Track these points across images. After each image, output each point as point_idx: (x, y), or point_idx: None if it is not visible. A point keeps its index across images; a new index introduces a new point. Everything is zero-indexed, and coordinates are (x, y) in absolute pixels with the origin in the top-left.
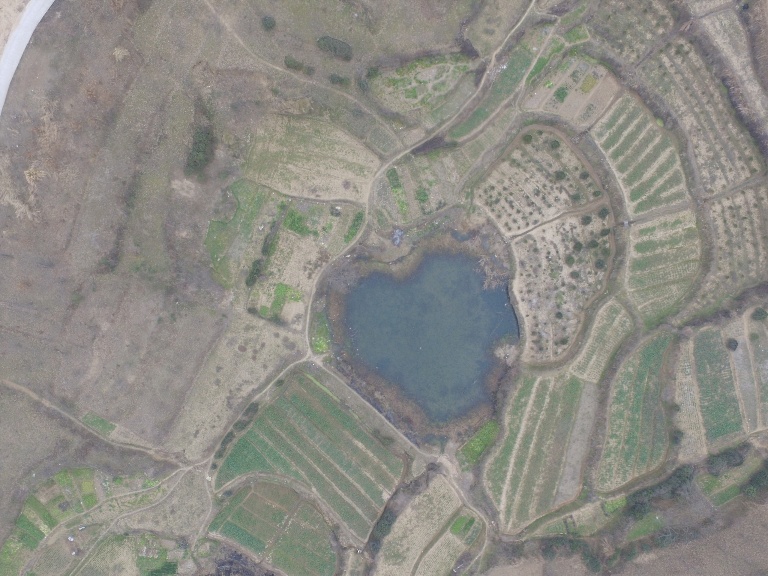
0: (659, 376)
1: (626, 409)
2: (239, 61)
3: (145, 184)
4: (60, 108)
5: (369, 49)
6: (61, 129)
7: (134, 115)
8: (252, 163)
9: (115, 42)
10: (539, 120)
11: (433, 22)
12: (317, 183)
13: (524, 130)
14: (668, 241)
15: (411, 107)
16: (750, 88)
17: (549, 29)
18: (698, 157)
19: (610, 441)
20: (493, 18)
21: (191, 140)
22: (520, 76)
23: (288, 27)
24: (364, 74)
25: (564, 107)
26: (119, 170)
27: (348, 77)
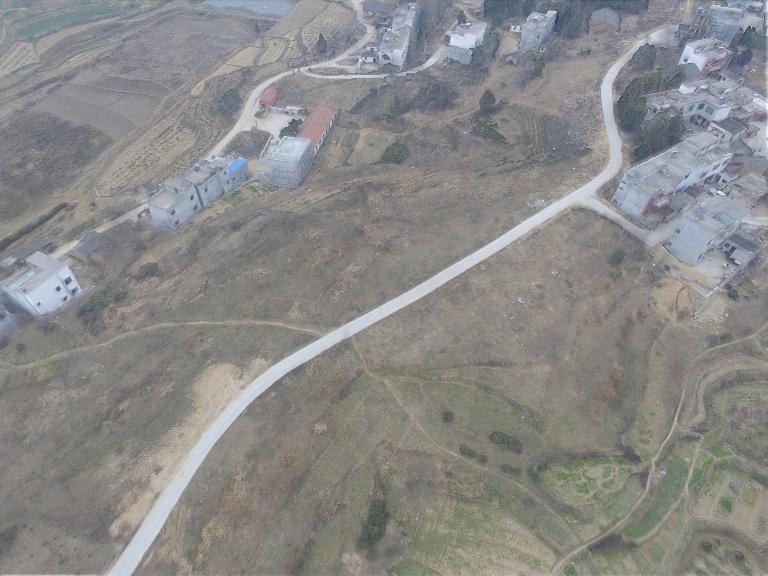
0: None
1: None
2: (419, 444)
3: (315, 555)
4: (253, 470)
5: (537, 445)
6: (249, 489)
7: (319, 483)
8: (419, 542)
9: (315, 419)
10: (711, 527)
11: (593, 429)
12: (489, 572)
13: (698, 536)
14: None
15: (585, 501)
16: None
17: (695, 444)
18: None
19: None
20: (645, 430)
21: (366, 512)
22: (681, 482)
23: (464, 421)
24: (535, 466)
25: (734, 516)
26: (294, 537)
27: (520, 468)
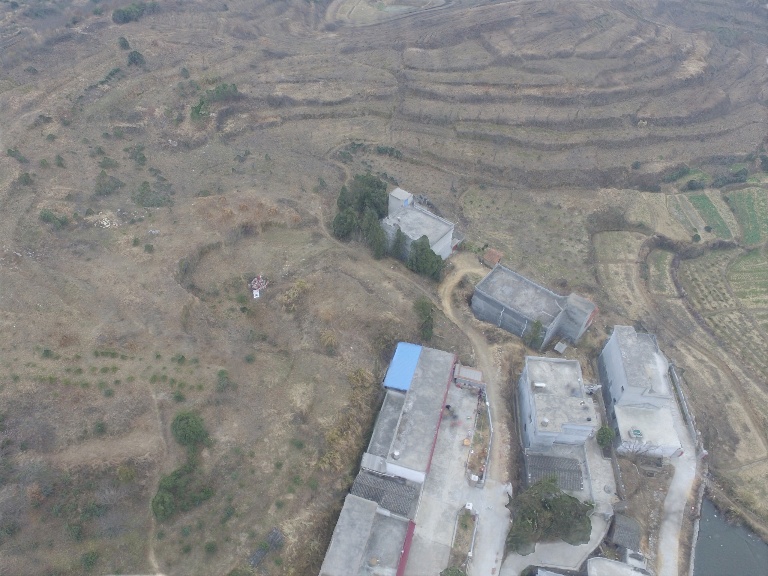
0: (743, 227)
1: (760, 216)
2: None
3: None
4: None
5: None
6: None
7: None
8: None
9: None
10: None
11: None
12: None
13: None
14: (759, 293)
15: None
16: (737, 367)
17: None
18: (759, 334)
19: (765, 205)
20: None
21: None
22: None
23: None
24: None
25: None
26: None
27: None
